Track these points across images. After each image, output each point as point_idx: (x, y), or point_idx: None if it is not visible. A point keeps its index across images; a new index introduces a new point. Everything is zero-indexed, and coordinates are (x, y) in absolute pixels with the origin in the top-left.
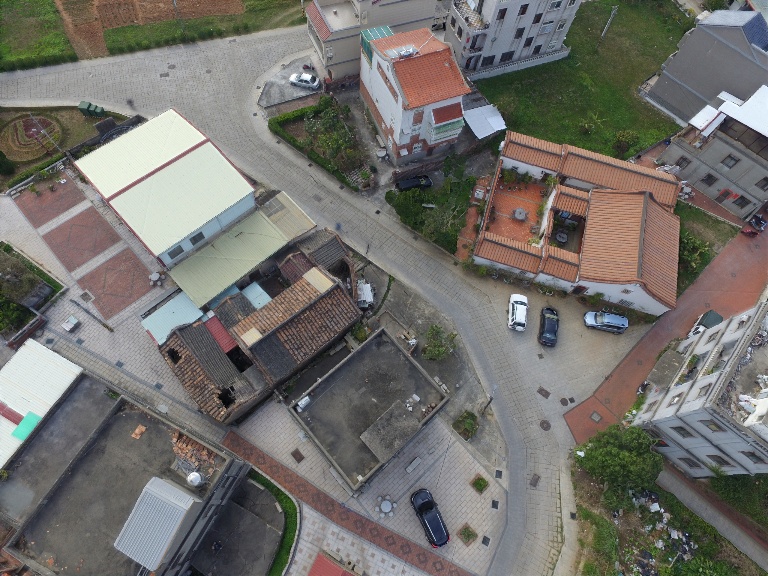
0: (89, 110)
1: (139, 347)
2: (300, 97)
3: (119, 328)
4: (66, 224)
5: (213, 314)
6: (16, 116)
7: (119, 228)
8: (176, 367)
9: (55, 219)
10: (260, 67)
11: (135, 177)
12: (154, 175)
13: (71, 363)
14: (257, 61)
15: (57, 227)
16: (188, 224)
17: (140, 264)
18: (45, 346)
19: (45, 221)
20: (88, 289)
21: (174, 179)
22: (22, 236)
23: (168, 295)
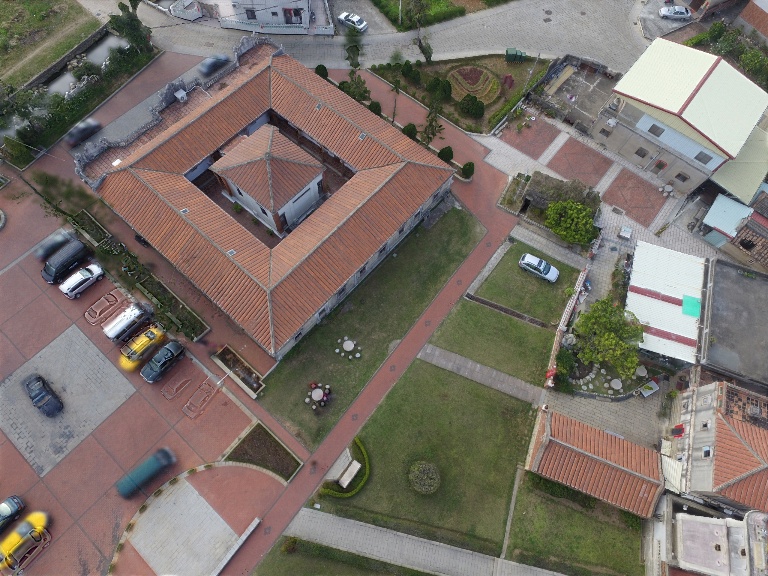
0: (516, 55)
1: (689, 246)
2: (680, 28)
3: (662, 233)
4: (559, 154)
5: (753, 210)
6: (447, 68)
7: (606, 153)
8: (755, 253)
9: (547, 151)
10: (624, 5)
11: (685, 94)
12: (700, 91)
13: (689, 255)
14: (618, 0)
15: (554, 157)
16: (743, 130)
17: (643, 180)
18: (655, 245)
19: (540, 153)
20: (615, 205)
21: (714, 93)
22: (529, 167)
23: (683, 203)
